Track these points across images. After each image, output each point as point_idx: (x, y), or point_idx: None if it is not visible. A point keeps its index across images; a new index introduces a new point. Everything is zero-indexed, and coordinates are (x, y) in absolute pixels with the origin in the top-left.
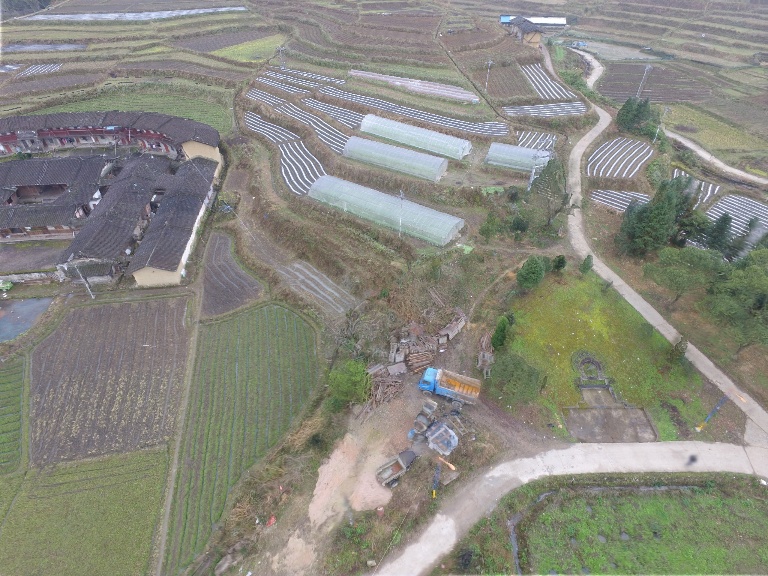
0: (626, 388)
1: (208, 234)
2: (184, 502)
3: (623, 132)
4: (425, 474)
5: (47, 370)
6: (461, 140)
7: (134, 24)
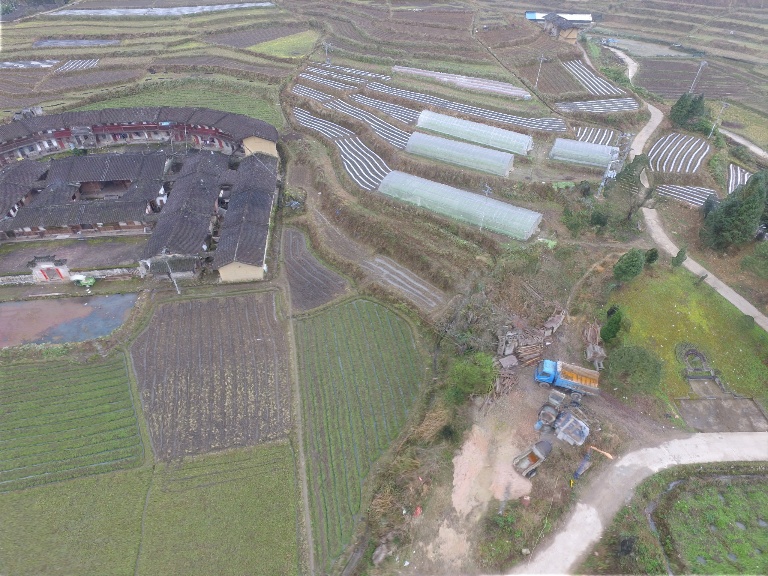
0: (733, 379)
1: (280, 230)
2: (320, 494)
3: (676, 128)
4: (560, 464)
5: (150, 365)
6: (524, 135)
7: (163, 19)
